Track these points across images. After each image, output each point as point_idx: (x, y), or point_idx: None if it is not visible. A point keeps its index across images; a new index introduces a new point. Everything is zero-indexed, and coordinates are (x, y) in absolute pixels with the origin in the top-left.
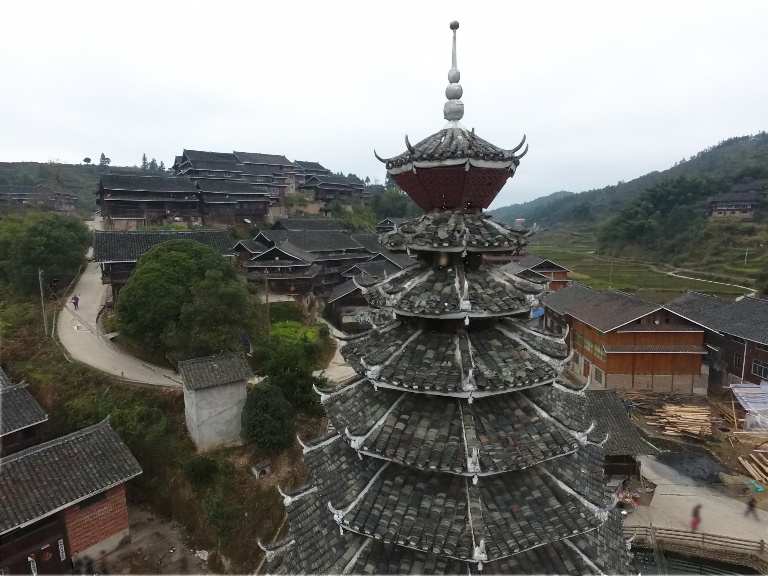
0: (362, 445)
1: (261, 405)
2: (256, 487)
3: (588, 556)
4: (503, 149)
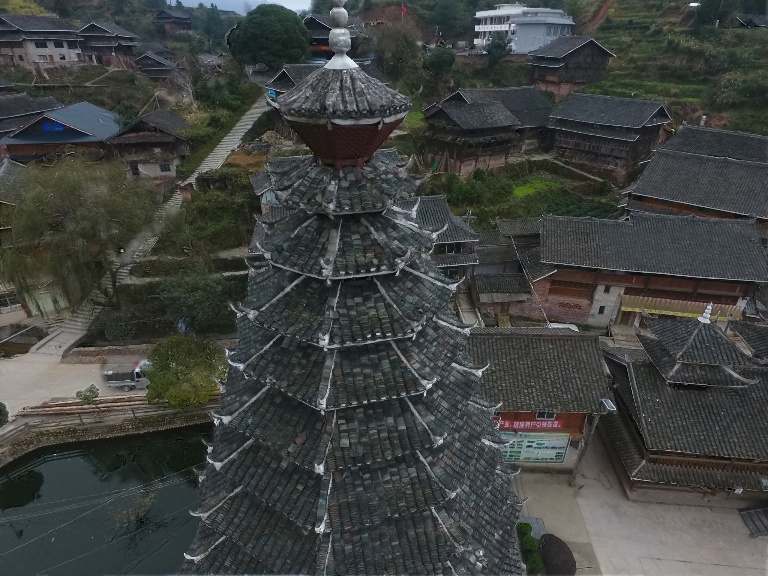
0: None
1: None
2: None
3: None
4: None
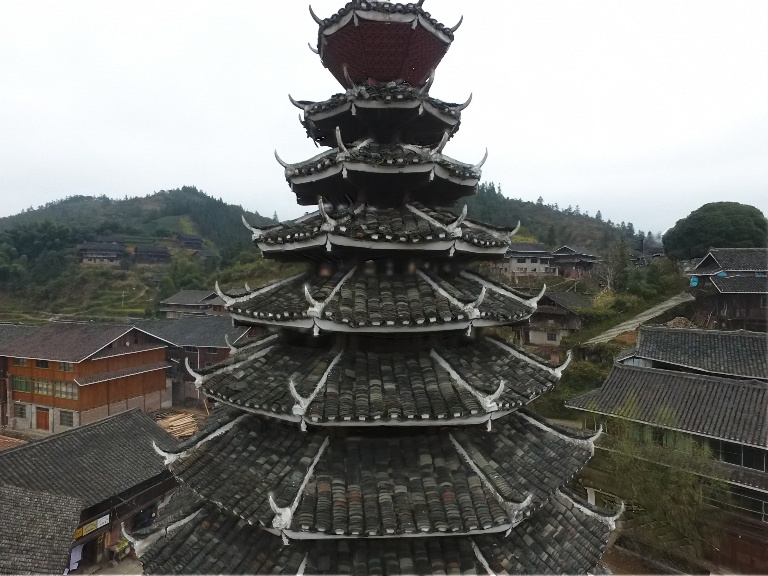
0: None
1: None
2: None
3: None
4: None
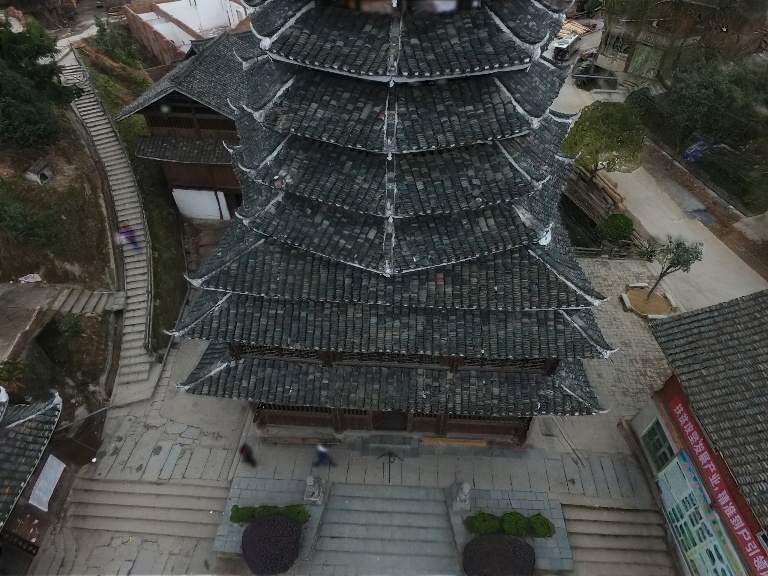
0: None
1: None
2: (51, 190)
3: (539, 1)
4: None
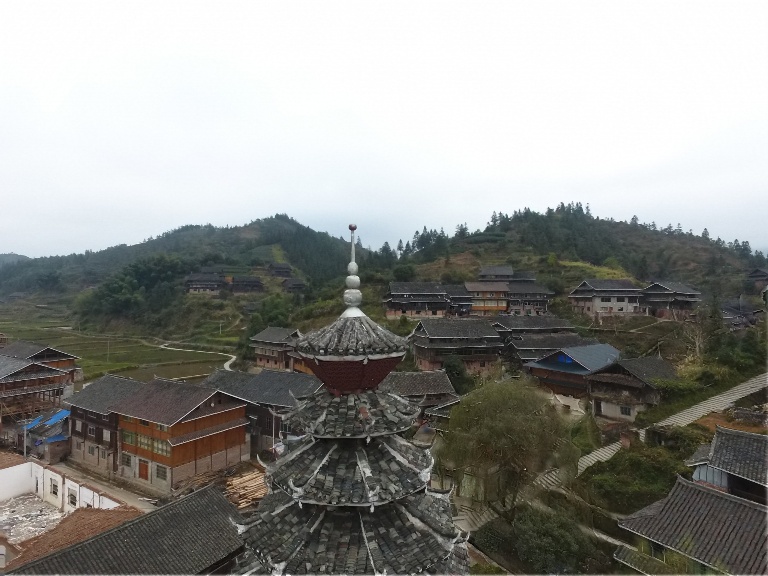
0: None
1: None
2: None
3: None
4: None
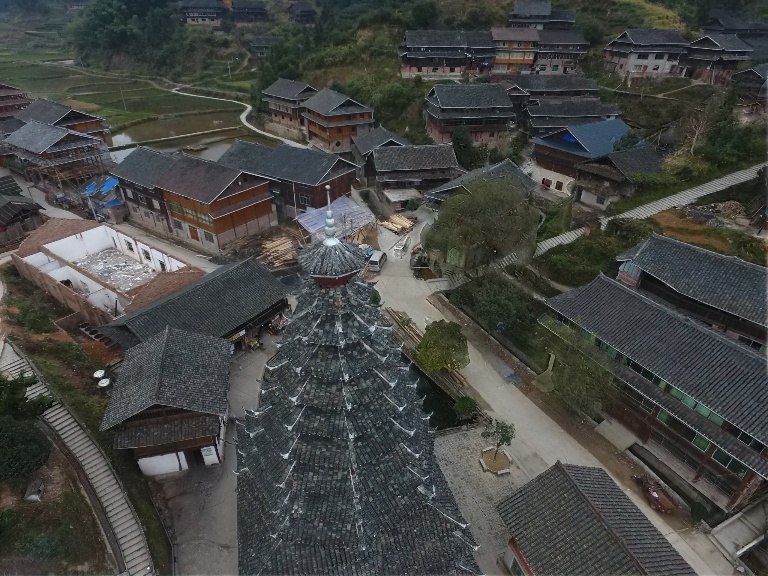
0: (352, 406)
1: (5, 443)
2: (54, 505)
3: None
4: (361, 250)
